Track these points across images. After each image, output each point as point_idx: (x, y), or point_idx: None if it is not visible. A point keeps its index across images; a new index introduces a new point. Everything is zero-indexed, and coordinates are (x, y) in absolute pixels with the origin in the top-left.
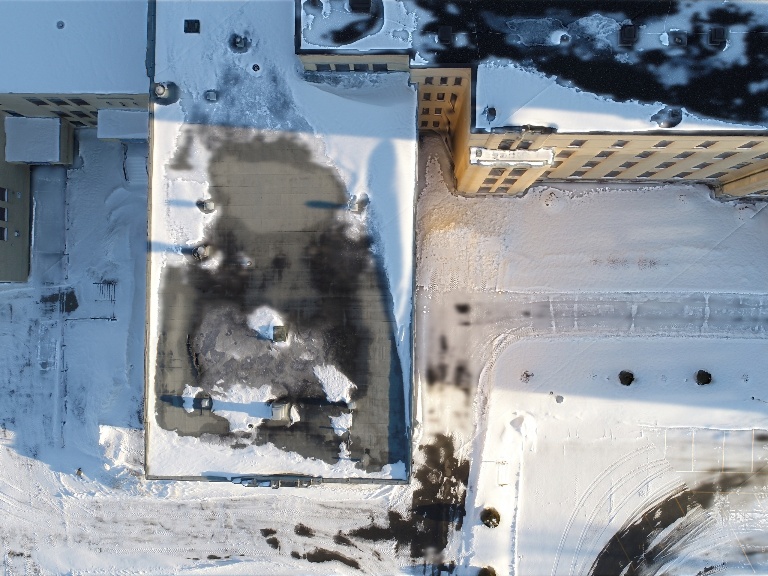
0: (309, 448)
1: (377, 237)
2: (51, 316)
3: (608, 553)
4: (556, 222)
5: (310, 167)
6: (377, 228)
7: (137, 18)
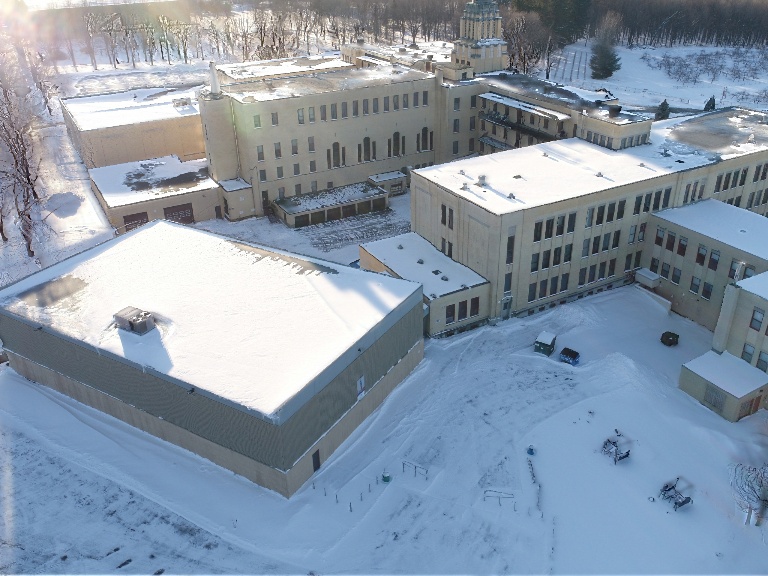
0: None
1: None
2: None
3: None
4: None
5: None
6: None
7: None
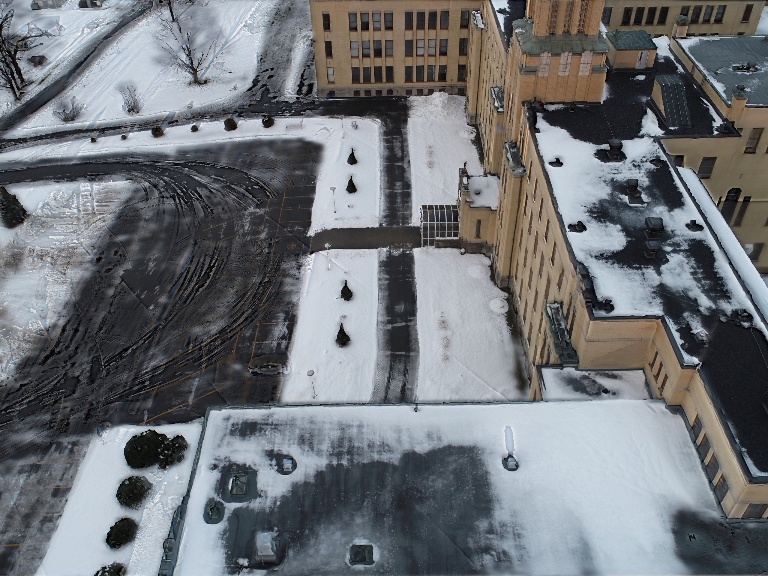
0: None
1: None
2: None
3: (234, 171)
4: (454, 135)
5: None
6: None
7: None
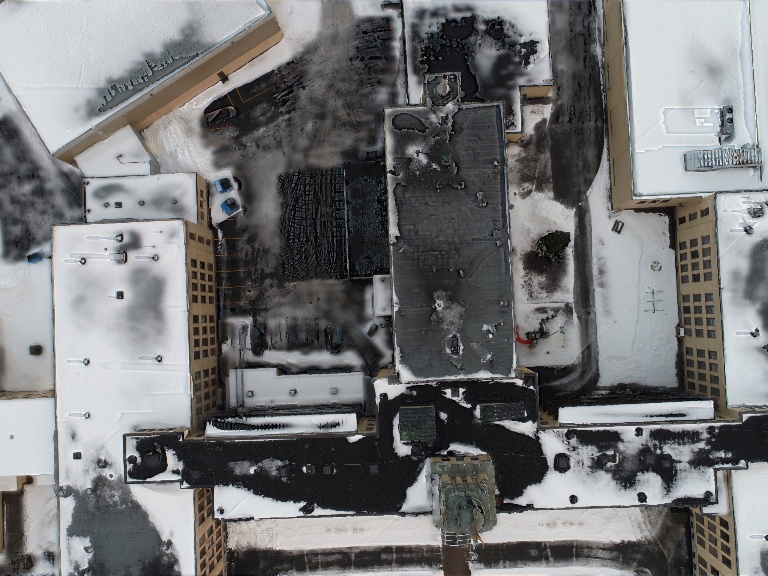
0: None
1: (177, 562)
2: (18, 572)
3: None
4: None
5: (141, 527)
6: (177, 557)
7: (53, 432)
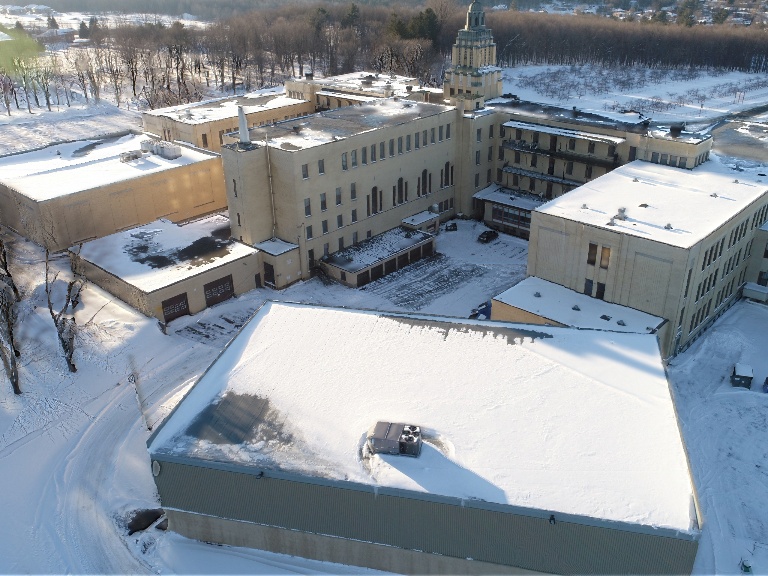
0: (764, 127)
1: None
2: None
3: None
4: None
5: None
6: None
7: None
